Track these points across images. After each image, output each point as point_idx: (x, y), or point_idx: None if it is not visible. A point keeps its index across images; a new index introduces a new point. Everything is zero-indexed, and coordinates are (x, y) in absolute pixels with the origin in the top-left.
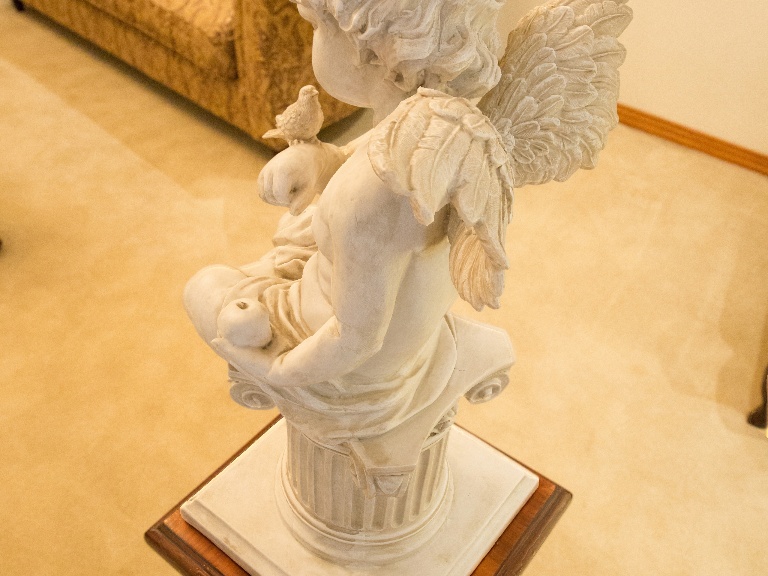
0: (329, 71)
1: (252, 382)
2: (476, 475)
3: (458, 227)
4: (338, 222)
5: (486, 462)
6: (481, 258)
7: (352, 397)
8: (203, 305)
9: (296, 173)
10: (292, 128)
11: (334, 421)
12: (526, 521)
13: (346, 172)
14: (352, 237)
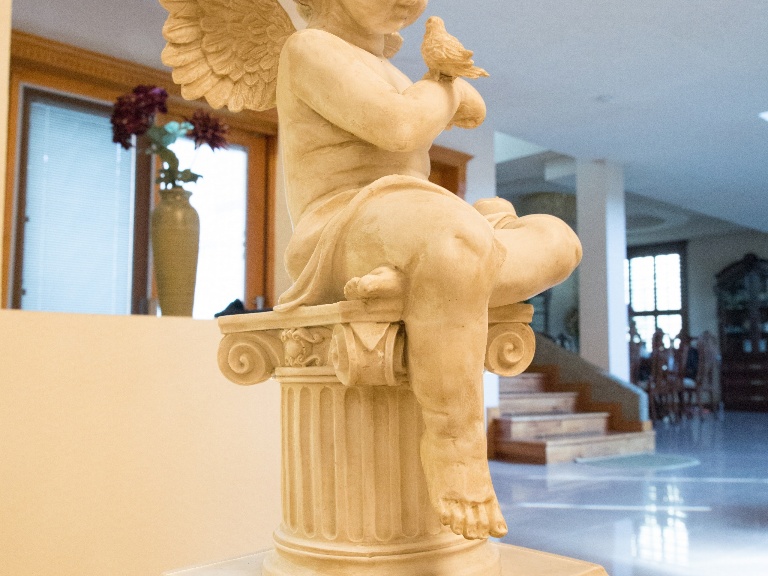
0: None
1: None
2: (230, 570)
3: None
4: None
5: (207, 575)
6: None
7: None
8: None
9: None
10: None
11: None
12: None
13: None
14: None
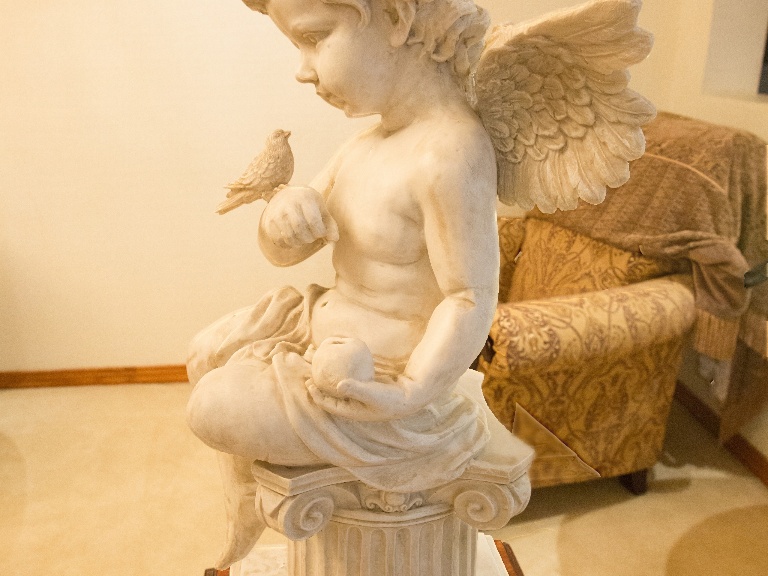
0: (361, 65)
1: (316, 484)
2: None
3: (517, 170)
4: (451, 177)
5: None
6: (594, 149)
7: (447, 419)
8: (250, 398)
9: (319, 199)
10: (273, 174)
11: (443, 454)
12: (512, 575)
13: (404, 155)
14: (470, 185)
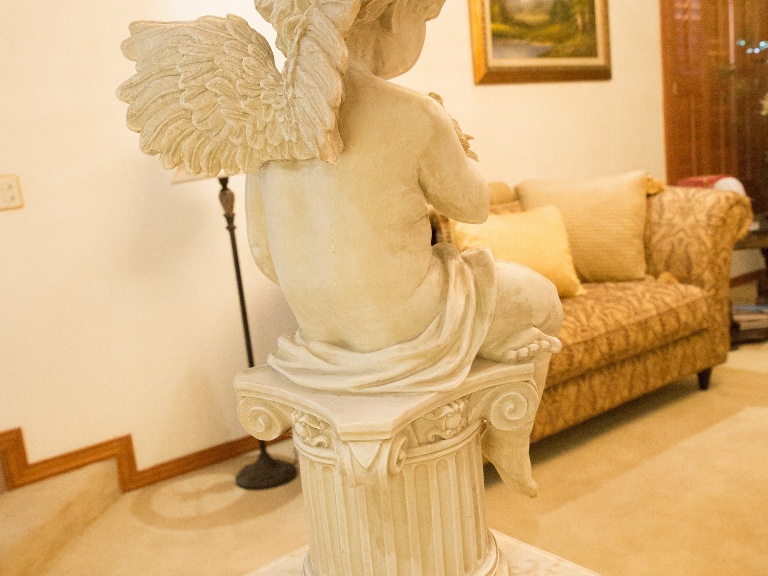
0: None
1: None
2: None
3: None
4: None
5: None
6: None
7: None
8: None
9: None
10: None
11: None
12: None
13: None
14: None
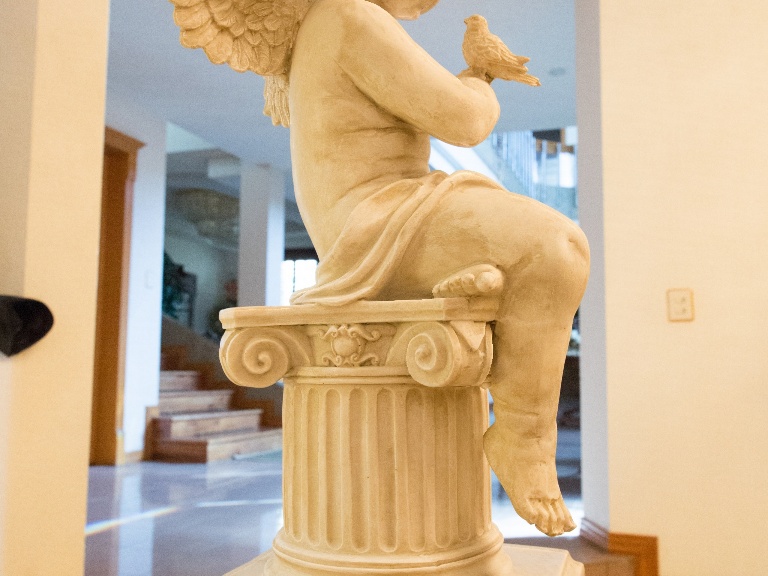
0: None
1: None
2: None
3: None
4: None
5: None
6: None
7: None
8: None
9: None
10: None
11: None
12: None
13: None
14: None
